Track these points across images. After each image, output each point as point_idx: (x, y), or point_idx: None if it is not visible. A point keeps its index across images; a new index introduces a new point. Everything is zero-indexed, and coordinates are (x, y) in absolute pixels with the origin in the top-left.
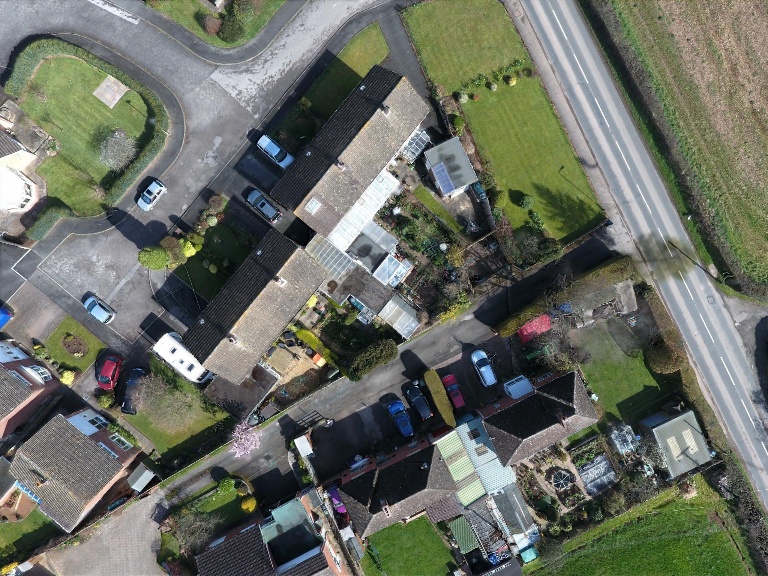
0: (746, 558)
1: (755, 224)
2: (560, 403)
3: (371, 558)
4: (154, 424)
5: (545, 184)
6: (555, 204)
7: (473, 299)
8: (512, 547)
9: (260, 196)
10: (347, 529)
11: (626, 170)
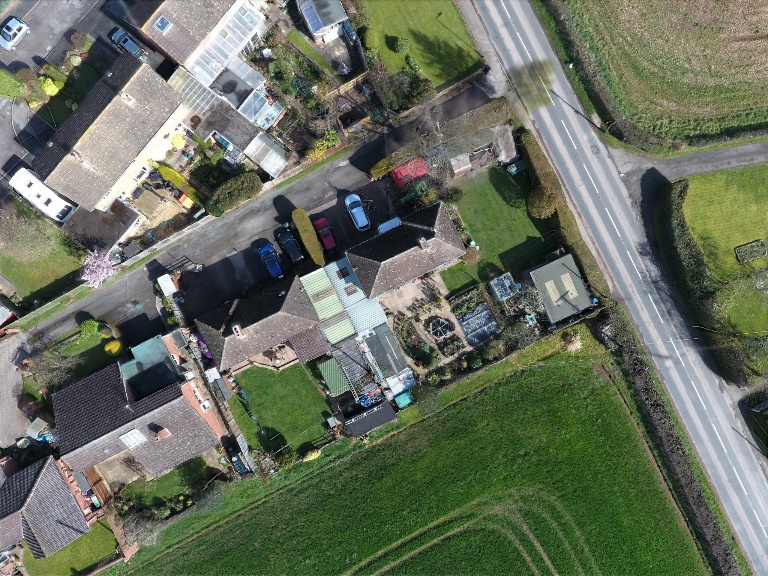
0: (634, 412)
1: (640, 75)
2: (422, 229)
3: (243, 406)
4: (16, 267)
5: (422, 30)
6: (433, 50)
7: (343, 138)
8: (386, 392)
9: (124, 34)
10: (212, 370)
11: (506, 17)
